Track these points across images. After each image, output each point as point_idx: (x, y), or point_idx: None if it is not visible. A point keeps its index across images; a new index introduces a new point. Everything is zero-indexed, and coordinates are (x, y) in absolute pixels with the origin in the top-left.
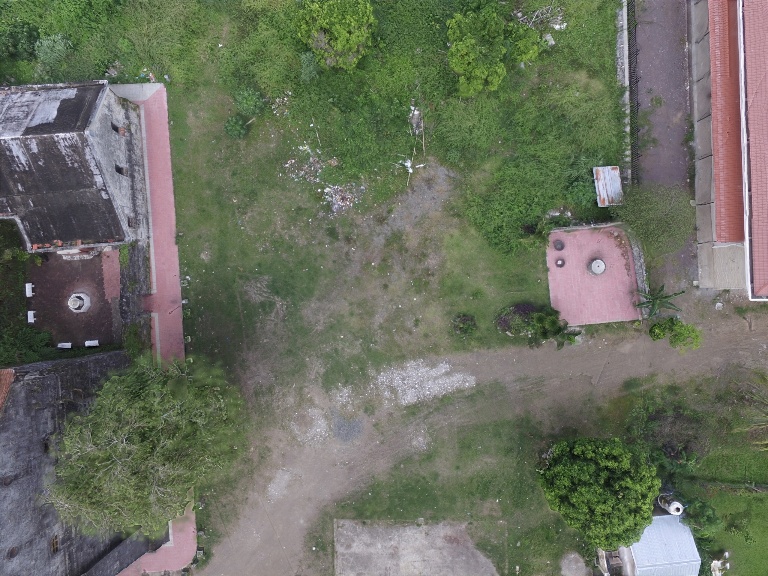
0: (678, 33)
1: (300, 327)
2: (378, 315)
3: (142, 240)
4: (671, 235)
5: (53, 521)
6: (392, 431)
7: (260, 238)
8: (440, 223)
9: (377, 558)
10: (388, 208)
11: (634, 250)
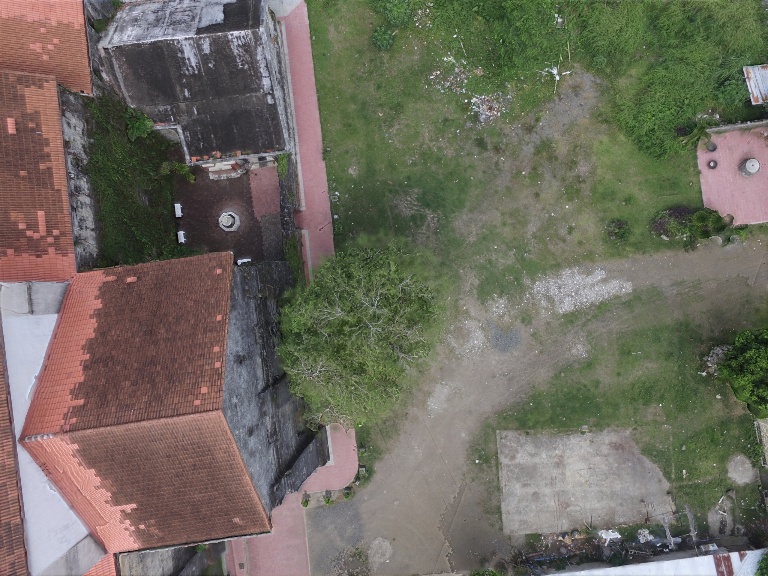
0: None
1: (453, 239)
2: (531, 224)
3: (293, 154)
4: None
5: (267, 411)
6: (550, 340)
7: (409, 150)
8: (589, 130)
9: (542, 468)
10: (536, 116)
11: None
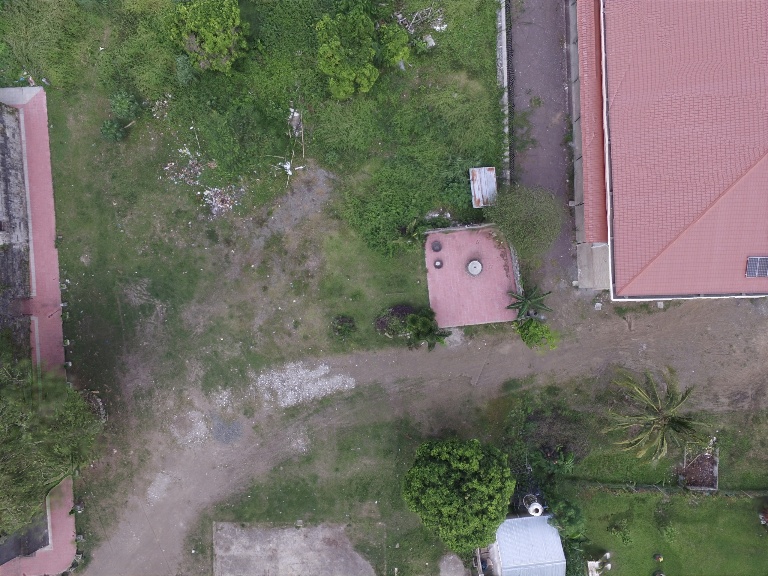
0: (557, 34)
1: (180, 330)
2: (258, 317)
3: (18, 244)
4: (537, 236)
5: None
6: (271, 433)
7: (139, 241)
8: (320, 225)
9: (256, 561)
10: (268, 210)
11: (511, 251)
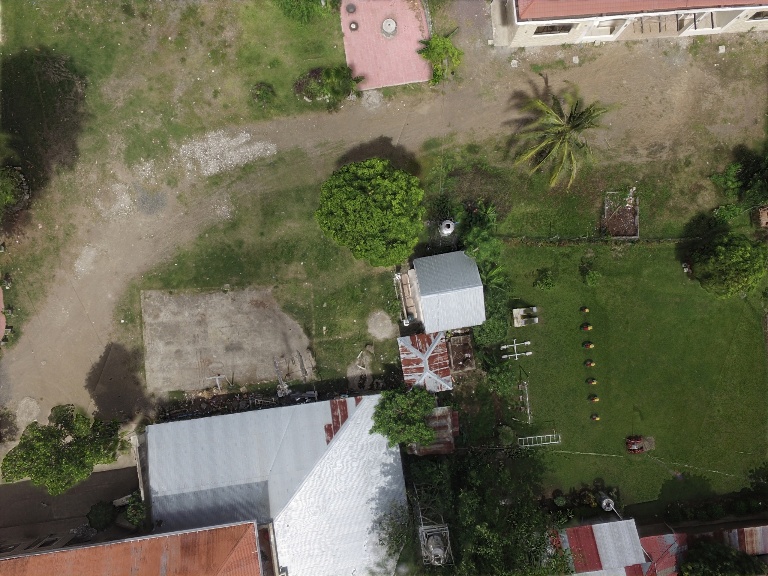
0: None
1: (100, 104)
2: (177, 89)
3: None
4: None
5: None
6: (196, 202)
7: (55, 17)
8: None
9: (185, 326)
10: None
11: (425, 8)
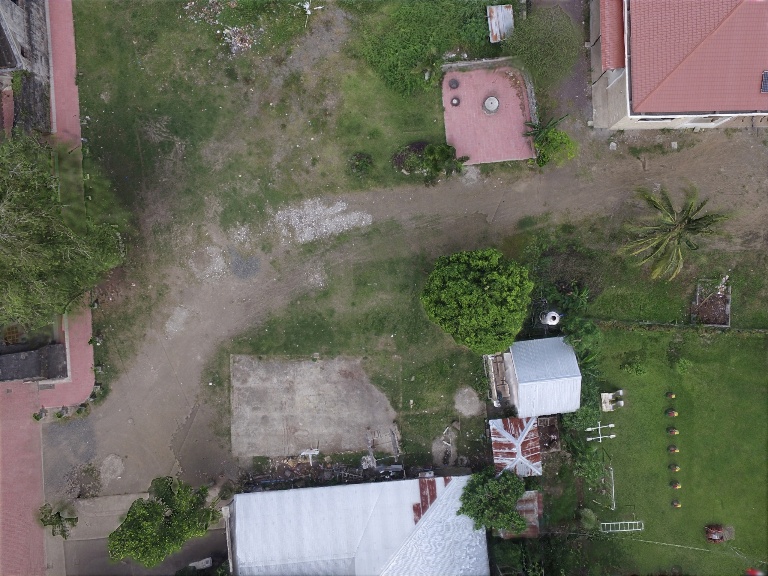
0: None
1: (199, 166)
2: (276, 154)
3: (40, 76)
4: (554, 58)
5: None
6: (289, 268)
7: (159, 78)
8: (338, 64)
9: (273, 392)
10: (286, 50)
11: (527, 88)
